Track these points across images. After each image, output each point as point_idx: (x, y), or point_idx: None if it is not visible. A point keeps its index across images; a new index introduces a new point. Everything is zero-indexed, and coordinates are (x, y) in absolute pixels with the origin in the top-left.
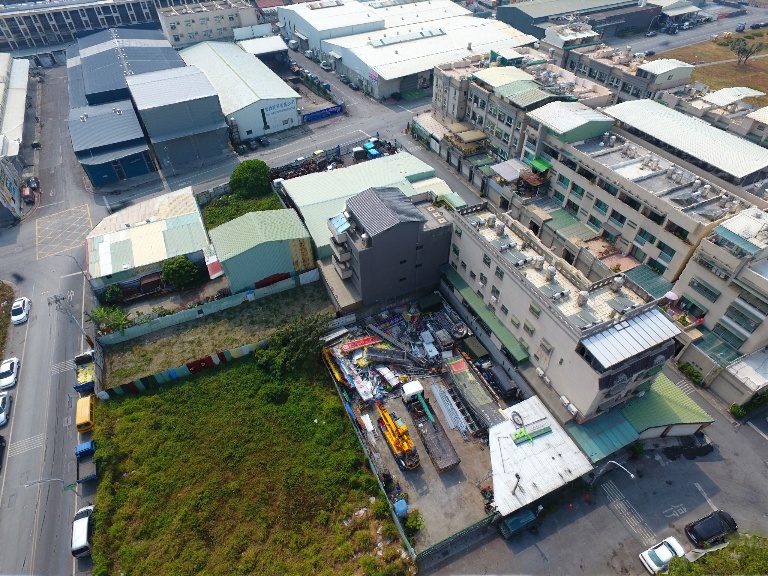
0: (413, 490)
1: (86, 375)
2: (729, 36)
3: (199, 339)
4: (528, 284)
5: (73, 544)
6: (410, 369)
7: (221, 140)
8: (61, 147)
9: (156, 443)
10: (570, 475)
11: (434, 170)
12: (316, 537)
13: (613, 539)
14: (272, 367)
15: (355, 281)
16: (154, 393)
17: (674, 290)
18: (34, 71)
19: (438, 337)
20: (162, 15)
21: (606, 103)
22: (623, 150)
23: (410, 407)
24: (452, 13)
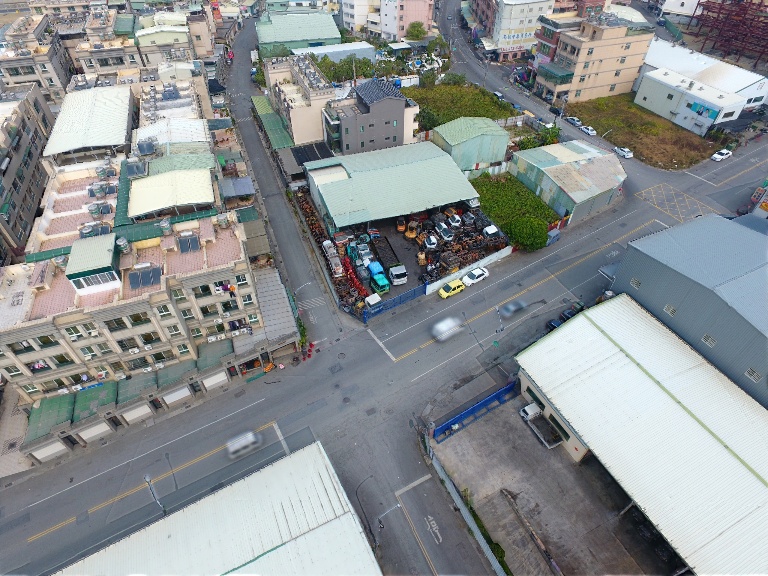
0: None
1: None
2: None
3: None
4: None
5: None
6: None
7: None
8: None
9: None
10: None
11: None
12: None
13: None
14: None
15: None
16: None
17: None
18: None
19: None
20: None
21: None
22: None
23: None
24: None
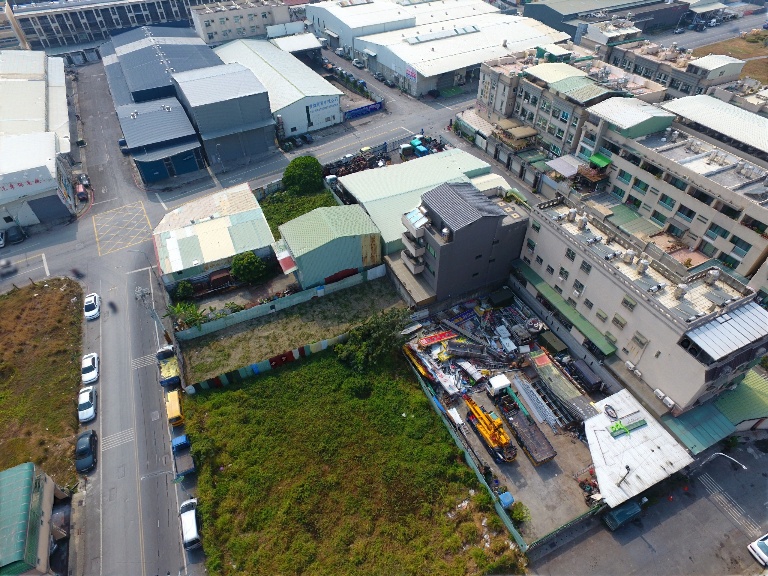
0: (511, 483)
1: (169, 370)
2: (758, 33)
3: (274, 334)
4: (622, 277)
5: (184, 536)
6: (490, 363)
7: (268, 137)
8: (106, 144)
9: (248, 437)
10: (672, 467)
11: (489, 166)
12: (423, 529)
13: (718, 531)
14: (354, 361)
15: (428, 276)
16: (238, 388)
17: (750, 284)
18: (67, 69)
19: (515, 332)
20: (196, 13)
21: (659, 99)
22: (687, 145)
23: (498, 401)
24: (480, 10)
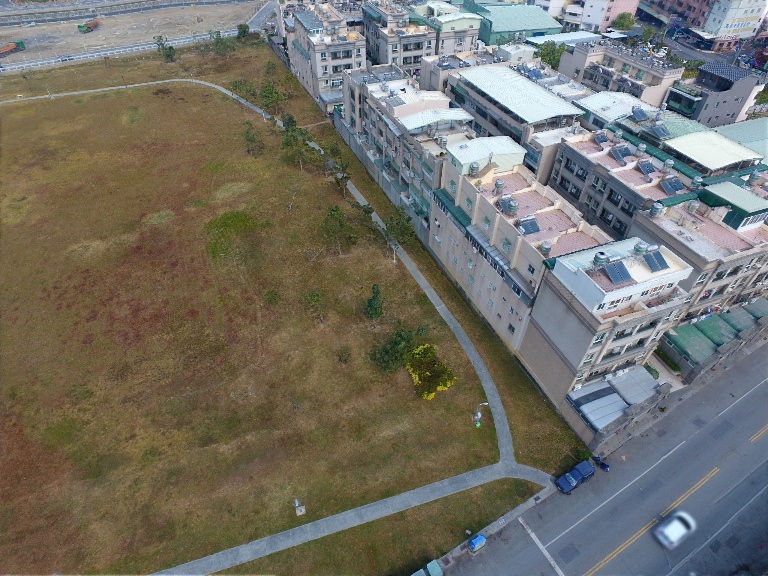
0: None
1: None
2: None
3: None
4: None
5: None
6: None
7: None
8: None
9: None
10: None
11: None
12: None
13: None
14: None
15: None
16: None
17: None
18: None
19: None
20: None
21: None
22: None
23: None
24: None
